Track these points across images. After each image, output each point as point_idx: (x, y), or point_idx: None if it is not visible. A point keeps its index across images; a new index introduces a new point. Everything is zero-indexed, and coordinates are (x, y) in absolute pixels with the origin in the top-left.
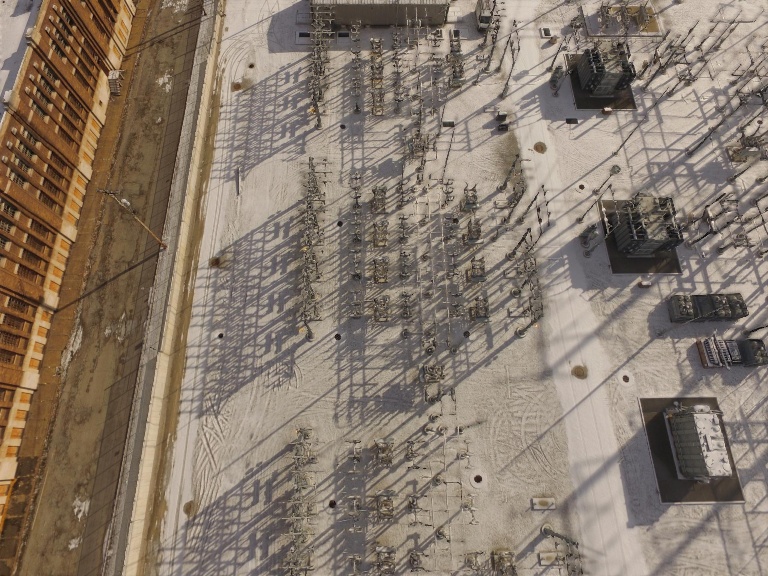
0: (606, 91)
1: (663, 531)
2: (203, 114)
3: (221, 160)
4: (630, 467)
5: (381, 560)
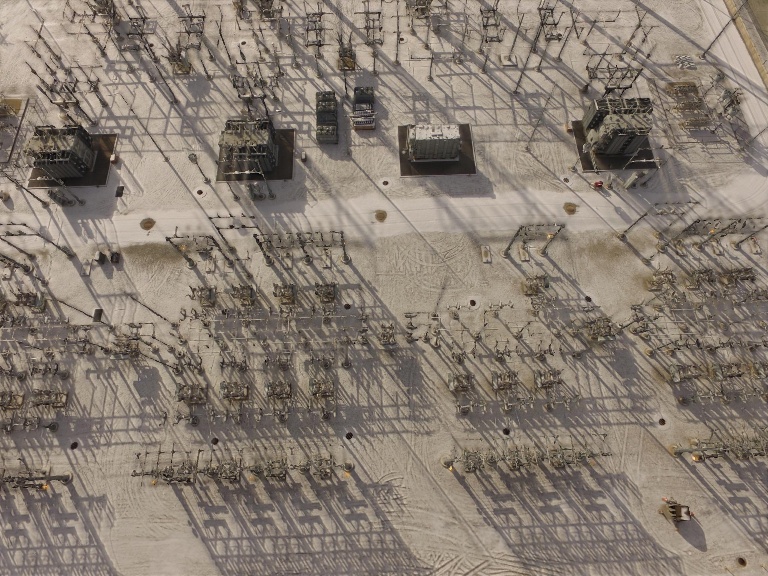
0: (90, 156)
1: (495, 176)
2: None
3: None
4: (453, 191)
5: (547, 383)
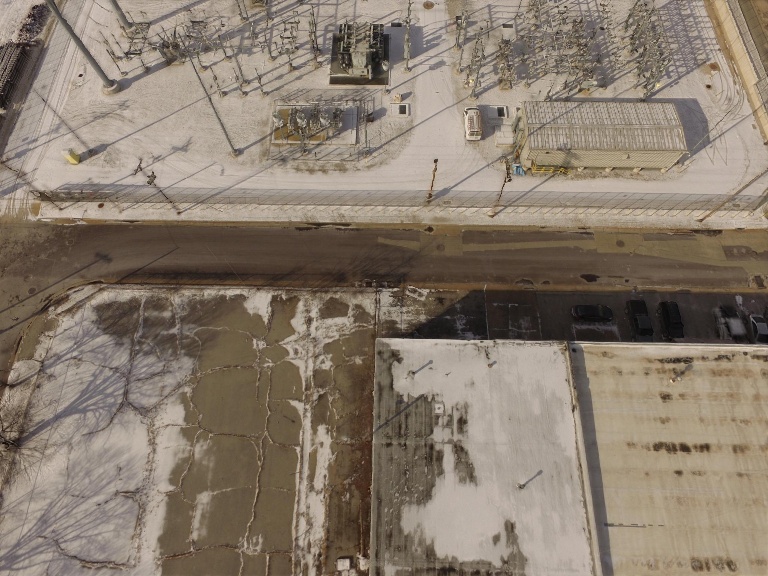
0: None
1: None
2: (733, 34)
3: (698, 8)
4: None
5: None
